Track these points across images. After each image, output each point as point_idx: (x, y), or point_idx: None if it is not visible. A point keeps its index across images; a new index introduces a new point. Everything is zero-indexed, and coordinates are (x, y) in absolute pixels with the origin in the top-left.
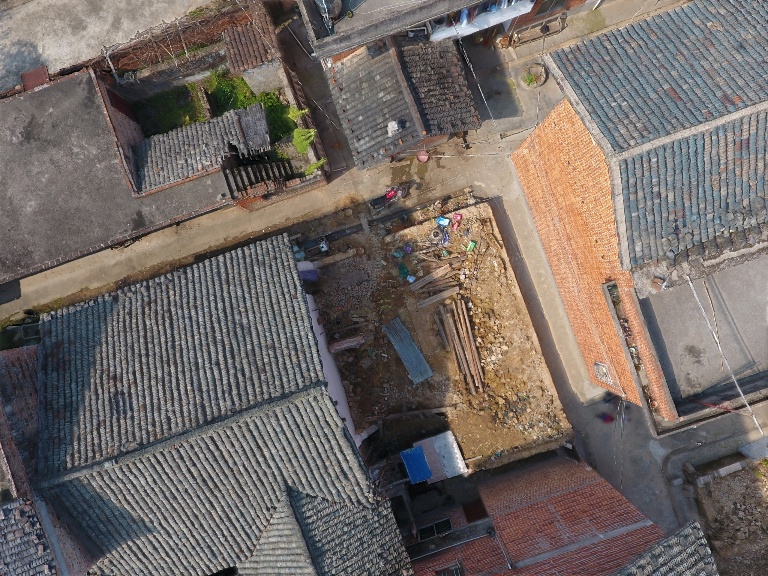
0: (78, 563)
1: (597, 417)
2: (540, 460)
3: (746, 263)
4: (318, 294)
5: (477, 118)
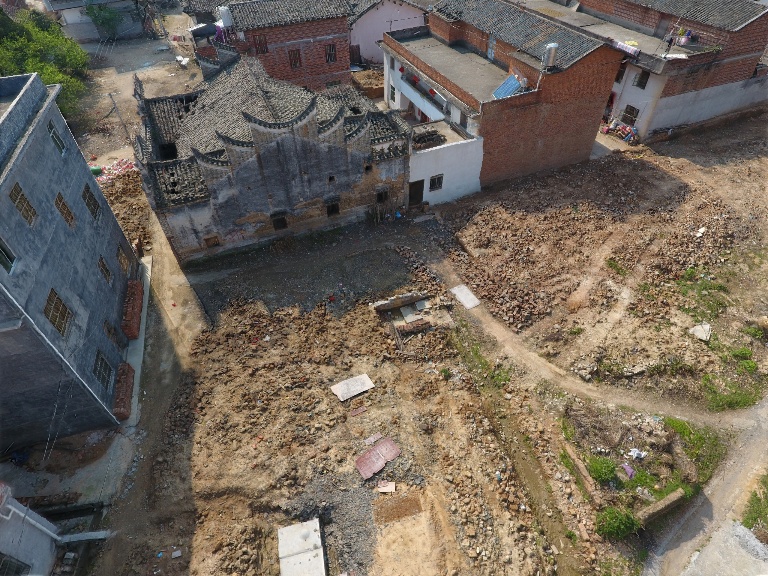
0: None
1: None
2: None
3: (443, 49)
4: None
5: None
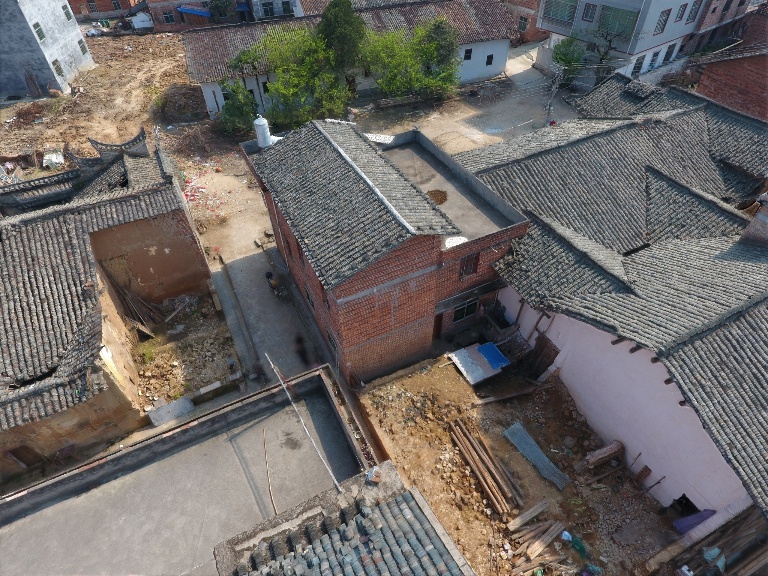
0: (759, 230)
1: None
2: (378, 377)
3: None
4: (659, 510)
5: None
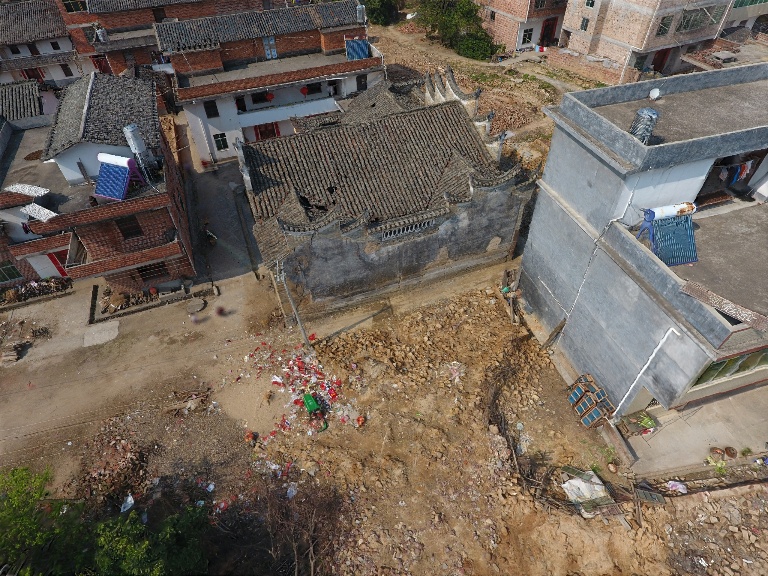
0: None
1: (204, 176)
2: None
3: (229, 74)
4: None
5: (164, 83)
